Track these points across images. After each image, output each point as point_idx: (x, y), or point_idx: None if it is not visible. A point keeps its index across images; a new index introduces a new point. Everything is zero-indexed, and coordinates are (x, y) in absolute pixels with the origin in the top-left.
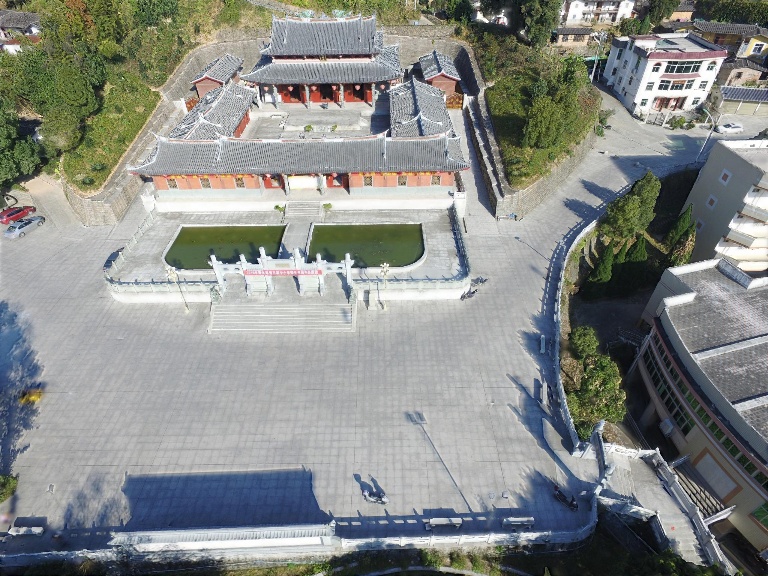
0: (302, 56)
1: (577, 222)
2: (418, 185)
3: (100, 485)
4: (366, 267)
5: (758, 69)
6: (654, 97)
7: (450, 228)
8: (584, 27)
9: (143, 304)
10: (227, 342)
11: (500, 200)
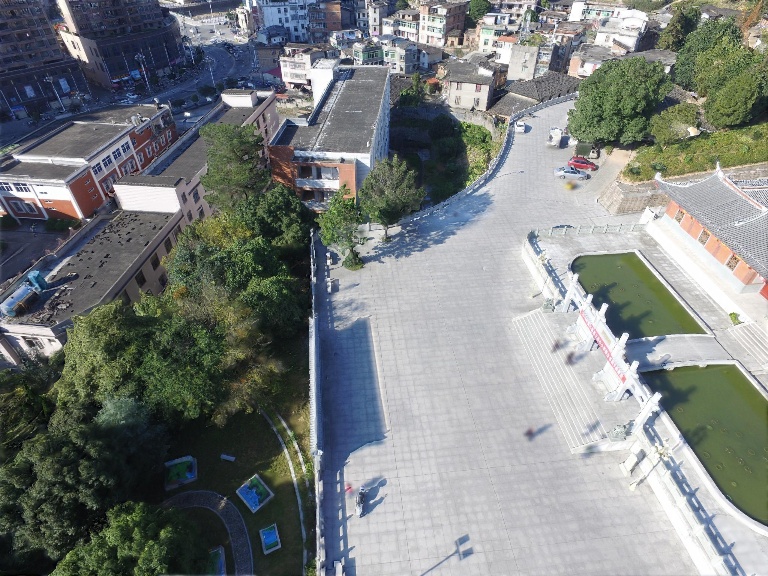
0: None
1: None
2: None
3: (361, 306)
4: (689, 443)
5: None
6: None
7: None
8: None
9: (526, 267)
10: (507, 336)
11: None
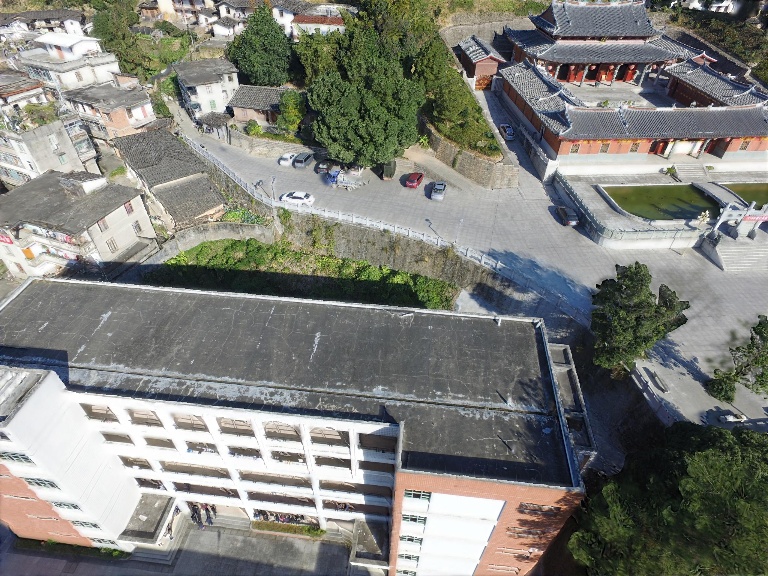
0: (585, 37)
1: None
2: None
3: None
4: None
5: None
6: None
7: None
8: None
9: (635, 250)
10: (749, 277)
11: None
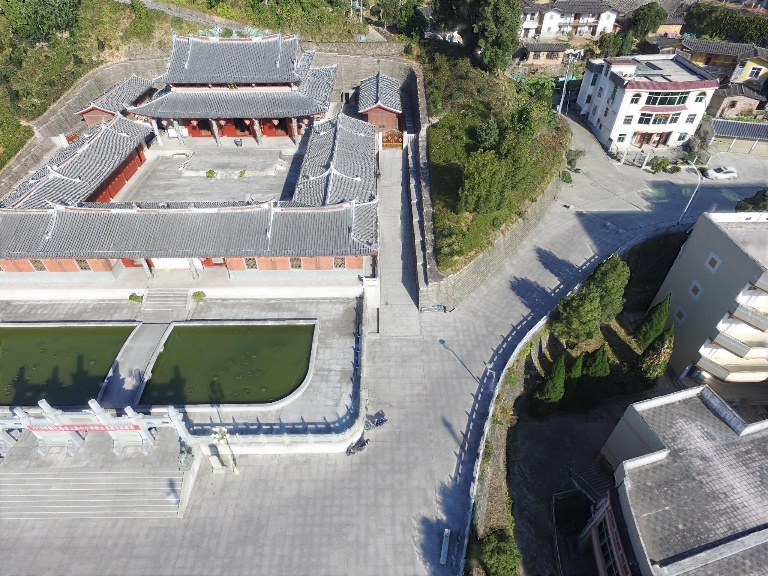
0: (207, 84)
1: (523, 315)
2: (317, 268)
3: None
4: (221, 403)
5: (755, 98)
6: (633, 132)
7: (353, 330)
8: (560, 42)
9: None
10: None
11: (423, 288)
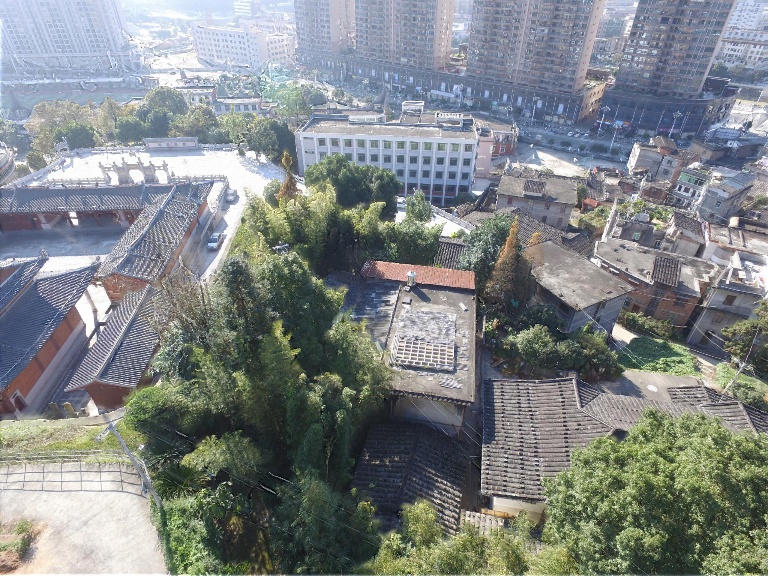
0: None
1: None
2: None
3: None
4: None
5: None
6: None
7: None
8: None
9: None
10: None
11: None
